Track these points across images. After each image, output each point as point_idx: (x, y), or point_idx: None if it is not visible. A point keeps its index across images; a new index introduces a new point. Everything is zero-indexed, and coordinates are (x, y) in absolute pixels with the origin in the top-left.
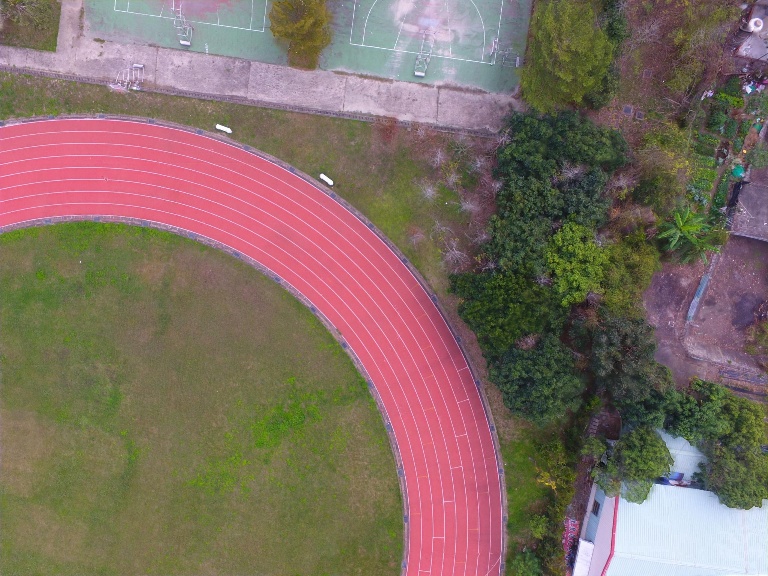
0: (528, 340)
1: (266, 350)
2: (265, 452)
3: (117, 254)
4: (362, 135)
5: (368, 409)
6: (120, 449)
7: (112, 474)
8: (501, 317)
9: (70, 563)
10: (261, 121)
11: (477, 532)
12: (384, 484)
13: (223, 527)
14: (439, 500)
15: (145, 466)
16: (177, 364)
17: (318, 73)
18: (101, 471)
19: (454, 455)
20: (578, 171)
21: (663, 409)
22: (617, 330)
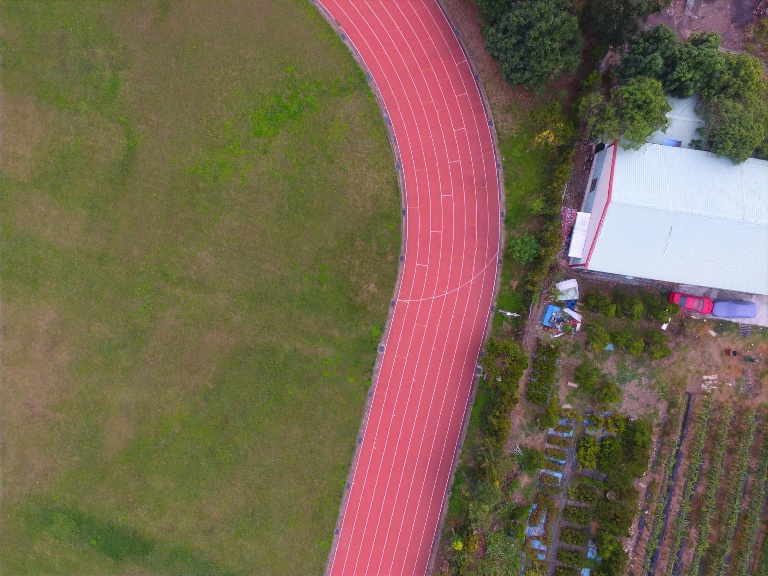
0: None
1: (265, 39)
2: (263, 142)
3: None
4: None
5: (366, 101)
6: (119, 135)
7: (111, 160)
8: None
9: (69, 248)
10: None
11: (475, 226)
12: (382, 177)
13: (221, 216)
14: (437, 194)
15: (144, 153)
16: (176, 51)
17: None
18: (100, 157)
19: (452, 149)
20: None
21: (661, 56)
22: None
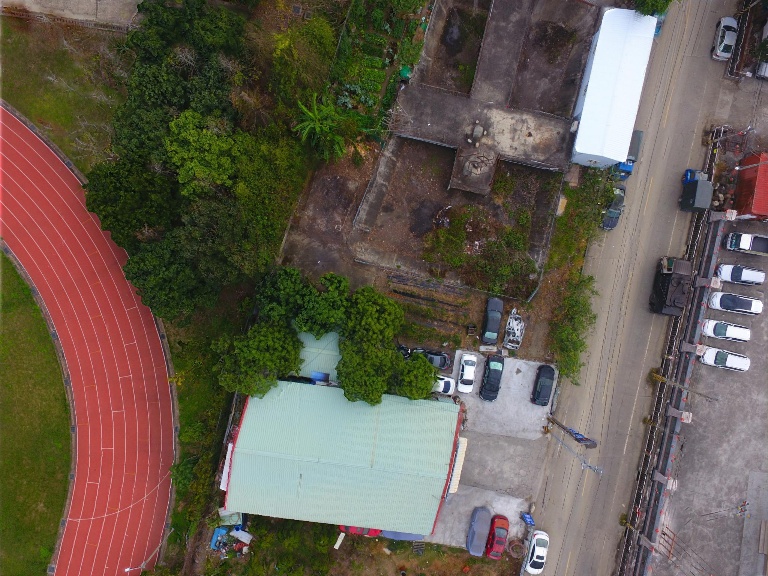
0: (143, 230)
1: None
2: None
3: None
4: (18, 32)
5: (31, 316)
6: None
7: None
8: (113, 206)
9: None
10: None
11: (147, 442)
12: (50, 393)
13: None
14: (108, 410)
15: None
16: None
17: None
18: None
19: (123, 364)
20: (199, 58)
21: (286, 302)
22: (198, 209)
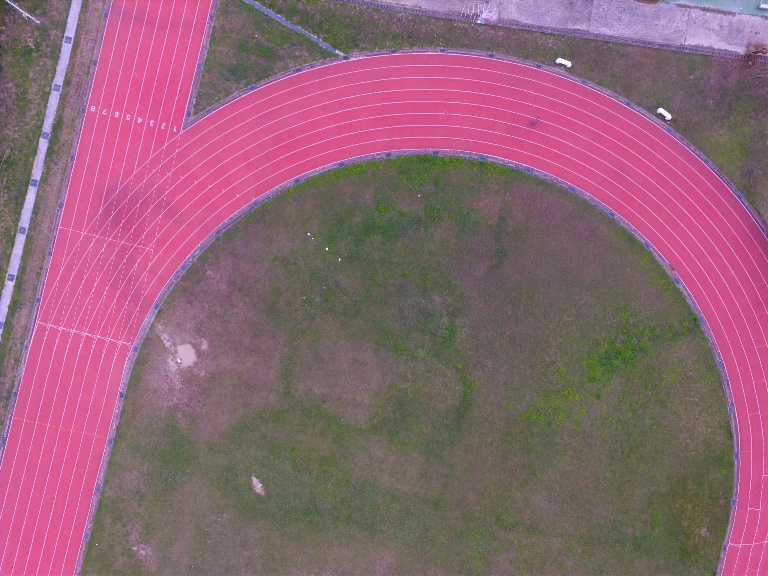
0: None
1: (600, 285)
2: (597, 387)
3: (455, 188)
4: (702, 69)
5: (700, 345)
6: (455, 382)
7: (447, 406)
8: None
9: (405, 494)
10: (601, 55)
11: None
12: (715, 421)
13: (555, 461)
14: None
15: (479, 399)
16: (512, 298)
17: (661, 6)
18: (436, 403)
19: None
20: None
21: None
22: None
